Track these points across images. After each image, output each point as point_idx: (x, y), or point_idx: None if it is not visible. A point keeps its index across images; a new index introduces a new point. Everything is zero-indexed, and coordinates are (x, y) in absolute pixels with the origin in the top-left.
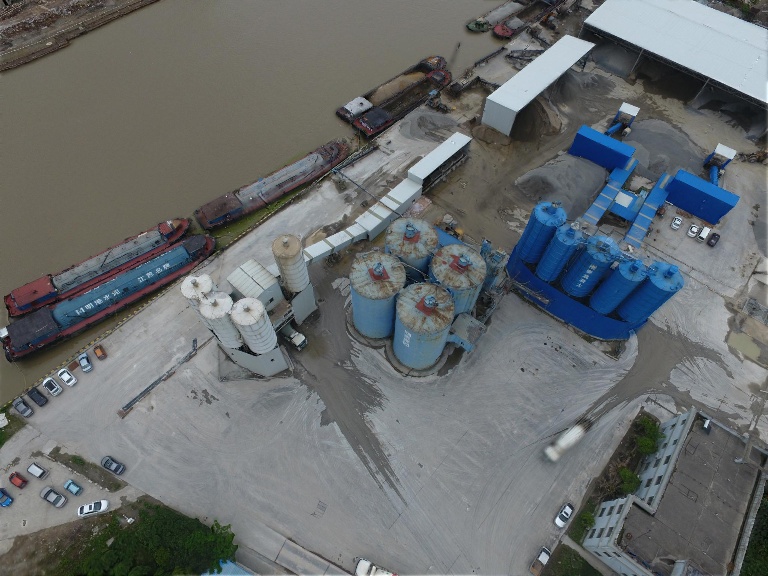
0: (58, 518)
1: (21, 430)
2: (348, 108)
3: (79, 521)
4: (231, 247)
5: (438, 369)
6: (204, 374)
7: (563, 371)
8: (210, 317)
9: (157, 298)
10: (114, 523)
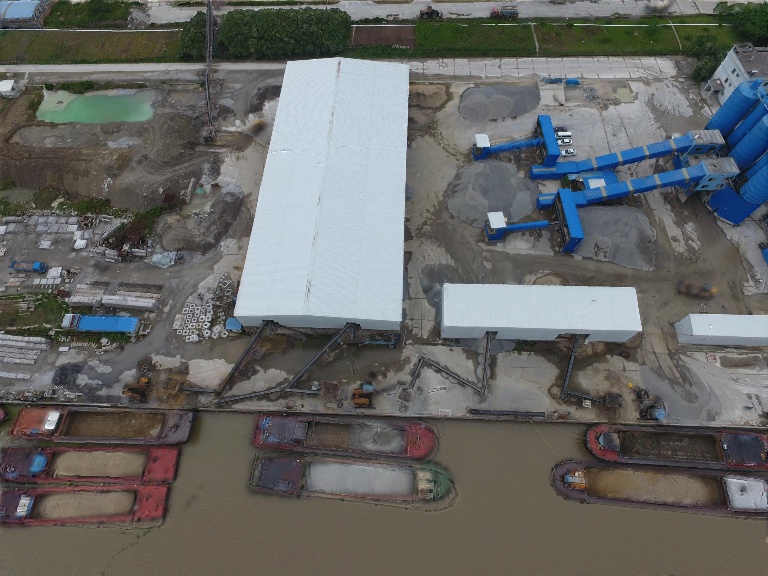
0: None
1: None
2: (766, 501)
3: None
4: None
5: None
6: None
7: None
8: None
9: None
10: None
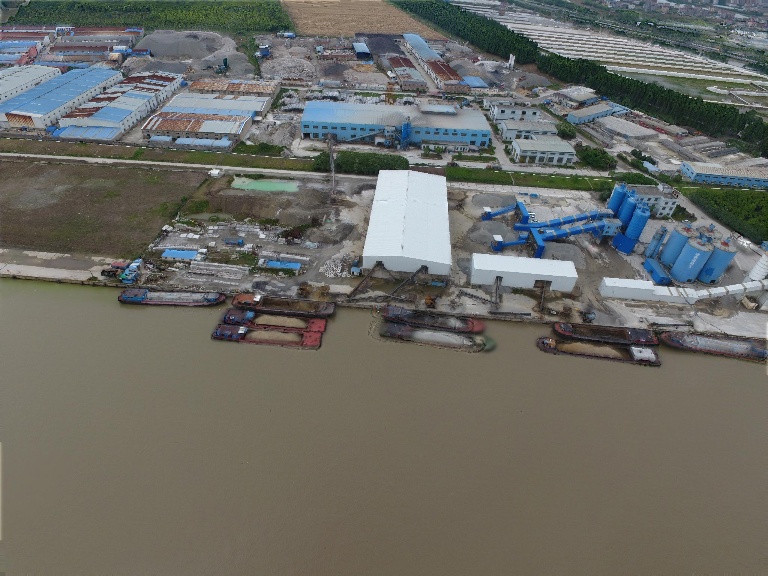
0: None
1: None
2: None
3: None
4: None
5: None
6: None
7: None
8: None
9: None
10: None
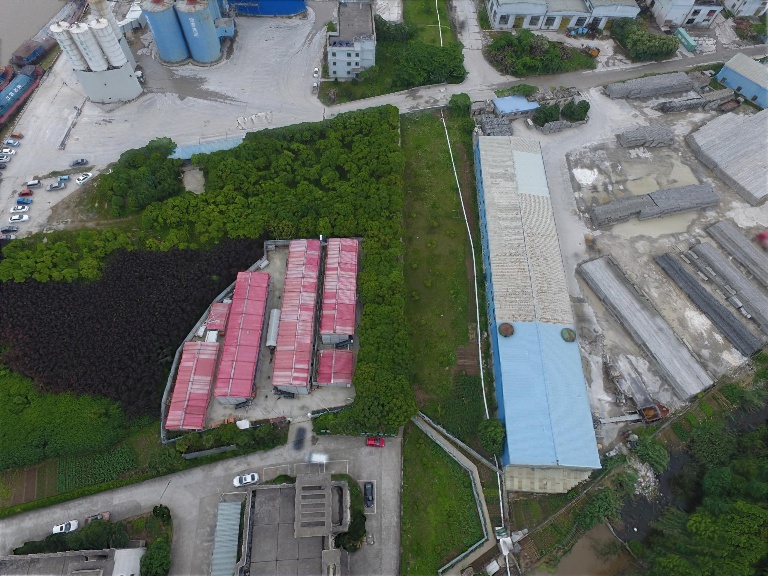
0: (68, 192)
1: (2, 182)
2: None
3: (81, 187)
4: (55, 65)
5: (225, 57)
6: (95, 115)
7: (285, 33)
8: (81, 32)
9: (28, 103)
10: (103, 175)
